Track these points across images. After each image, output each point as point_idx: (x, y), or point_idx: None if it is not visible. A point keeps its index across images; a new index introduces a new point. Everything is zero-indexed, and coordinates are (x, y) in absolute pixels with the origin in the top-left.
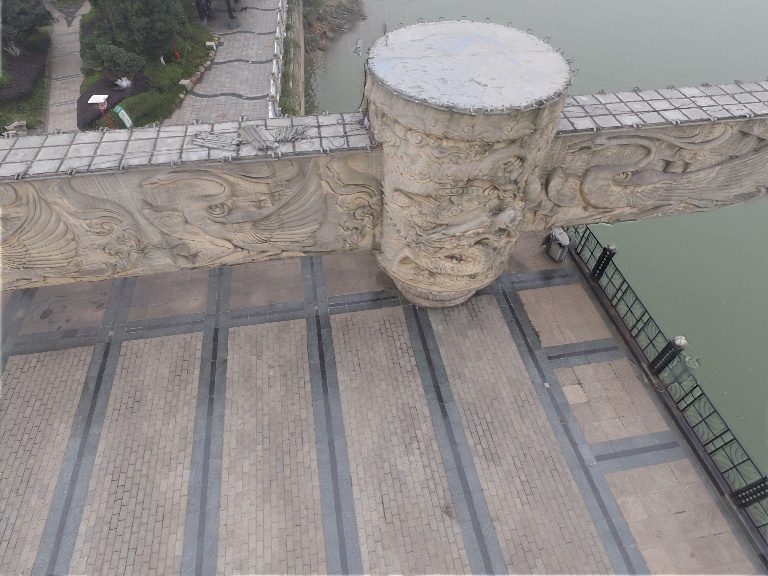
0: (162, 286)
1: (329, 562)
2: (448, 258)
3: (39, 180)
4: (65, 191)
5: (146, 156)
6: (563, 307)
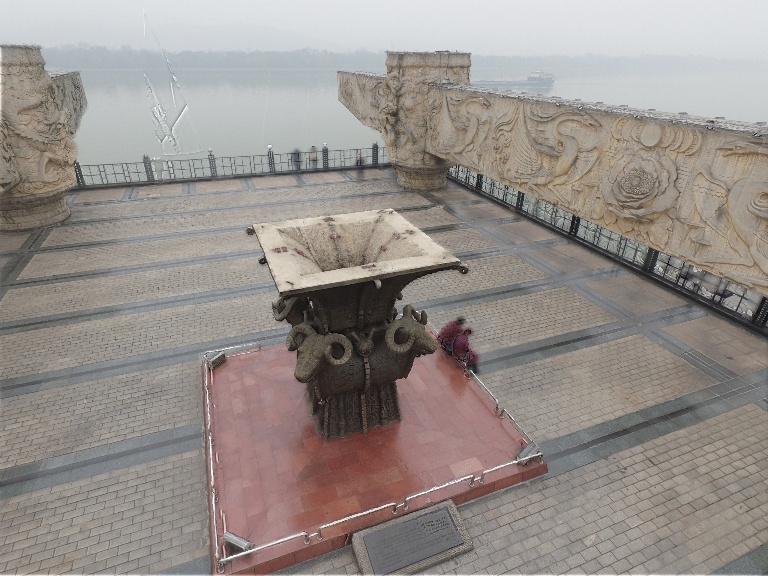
0: None
1: None
2: None
3: None
4: None
5: None
6: (96, 195)
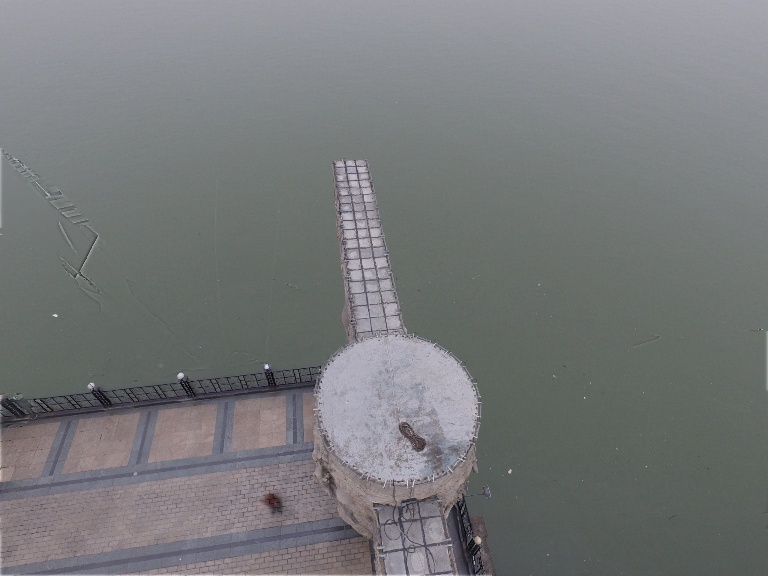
0: None
1: None
2: None
3: None
4: None
5: None
6: None
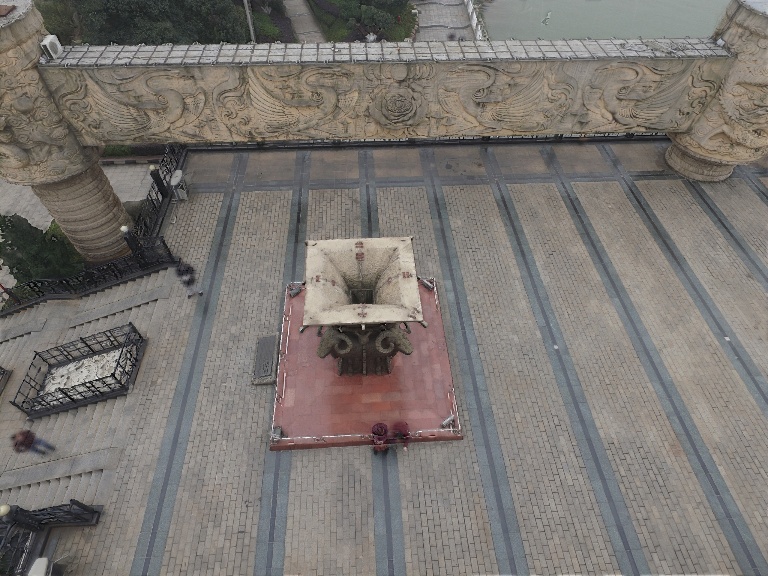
0: (513, 157)
1: (688, 290)
2: (754, 132)
3: (552, 61)
4: (559, 69)
5: (603, 53)
6: None
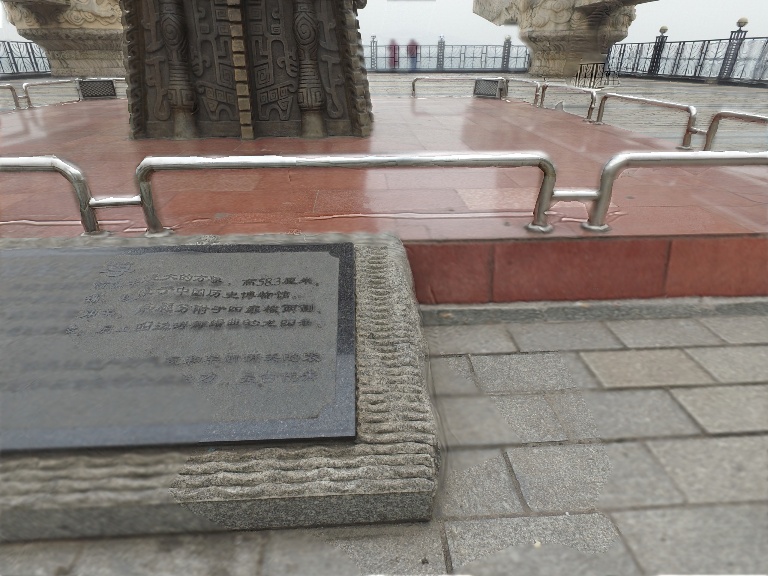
0: None
1: None
2: None
3: None
4: None
5: None
6: None
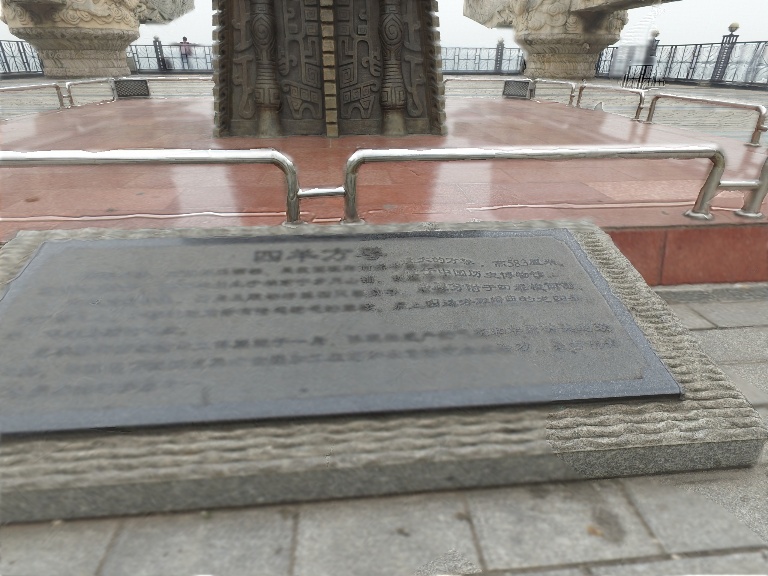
0: None
1: None
2: None
3: None
4: None
5: None
6: None
